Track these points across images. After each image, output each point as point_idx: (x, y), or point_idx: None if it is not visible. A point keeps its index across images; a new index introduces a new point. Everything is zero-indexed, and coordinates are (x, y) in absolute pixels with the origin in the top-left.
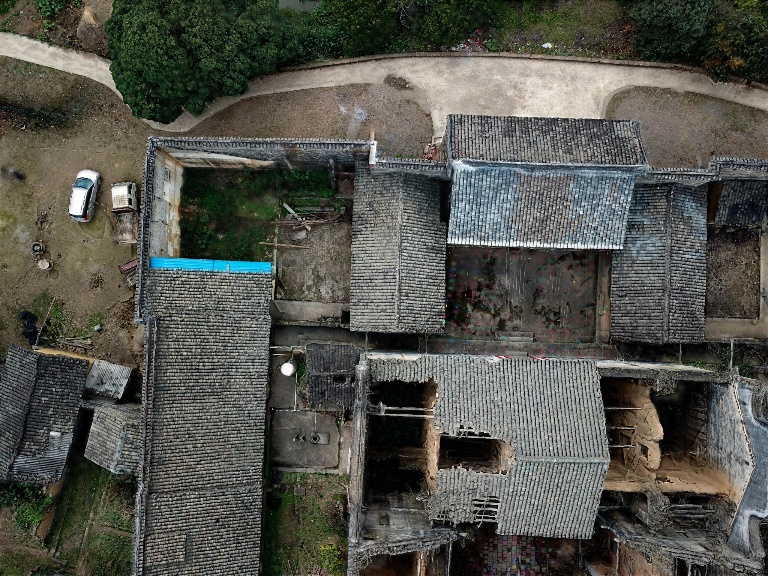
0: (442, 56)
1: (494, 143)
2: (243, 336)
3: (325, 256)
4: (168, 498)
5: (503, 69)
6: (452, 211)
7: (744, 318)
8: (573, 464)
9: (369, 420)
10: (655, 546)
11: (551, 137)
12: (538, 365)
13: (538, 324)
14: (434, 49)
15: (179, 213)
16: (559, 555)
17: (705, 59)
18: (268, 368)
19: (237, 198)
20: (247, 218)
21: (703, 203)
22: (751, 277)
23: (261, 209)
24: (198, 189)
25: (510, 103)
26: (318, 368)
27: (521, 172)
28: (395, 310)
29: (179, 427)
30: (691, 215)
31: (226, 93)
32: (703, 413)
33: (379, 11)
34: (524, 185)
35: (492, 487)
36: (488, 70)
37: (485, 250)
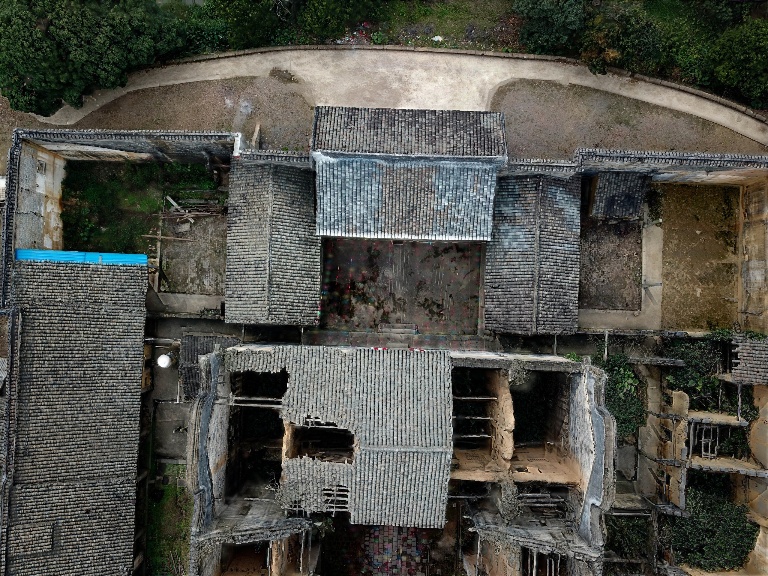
0: (327, 49)
1: (358, 135)
2: (116, 328)
3: (209, 249)
4: (34, 489)
5: (388, 62)
6: (318, 203)
7: (626, 310)
8: (416, 453)
9: (241, 411)
10: (503, 535)
11: (416, 129)
12: (391, 355)
13: (421, 316)
14: (319, 42)
15: (61, 206)
16: (440, 546)
17: (582, 51)
18: (146, 360)
19: (120, 191)
20: (130, 211)
21: (576, 195)
22: (633, 269)
23: (144, 202)
24: (81, 182)
25: (395, 96)
26: (191, 360)
27: (382, 163)
28: (265, 302)
29: (47, 418)
30: (563, 207)
31: (104, 86)
32: (565, 403)
33: (256, 4)
34: (387, 176)
35: (339, 476)
36: (373, 63)
37: (369, 242)
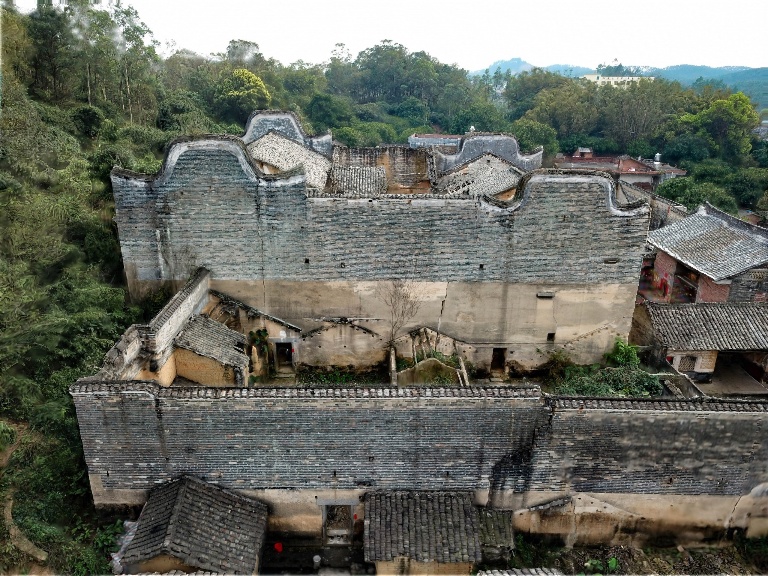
0: None
1: None
2: None
3: None
4: None
5: None
6: None
7: None
8: None
9: None
10: None
11: None
12: None
13: None
14: None
15: None
16: None
17: None
18: None
19: None
20: None
21: None
22: None
23: None
24: None
25: None
26: None
27: (725, 225)
28: None
29: None
30: None
31: None
32: None
33: None
34: None
35: None
36: None
37: None
